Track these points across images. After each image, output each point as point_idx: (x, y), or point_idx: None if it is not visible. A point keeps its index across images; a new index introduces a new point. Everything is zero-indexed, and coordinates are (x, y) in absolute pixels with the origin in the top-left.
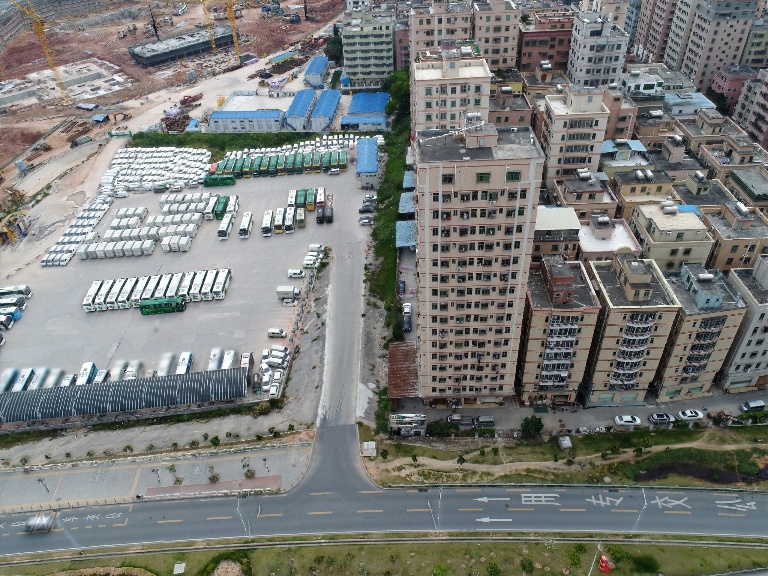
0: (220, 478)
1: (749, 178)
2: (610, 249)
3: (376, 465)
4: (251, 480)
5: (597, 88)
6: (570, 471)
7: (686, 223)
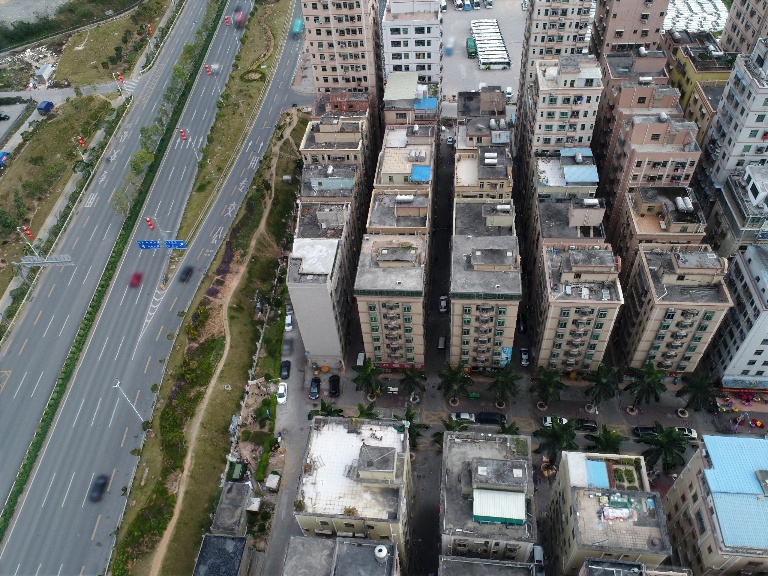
0: (305, 70)
1: (492, 243)
2: (393, 143)
3: (296, 112)
4: (301, 78)
5: (579, 70)
6: (266, 174)
7: (393, 164)
